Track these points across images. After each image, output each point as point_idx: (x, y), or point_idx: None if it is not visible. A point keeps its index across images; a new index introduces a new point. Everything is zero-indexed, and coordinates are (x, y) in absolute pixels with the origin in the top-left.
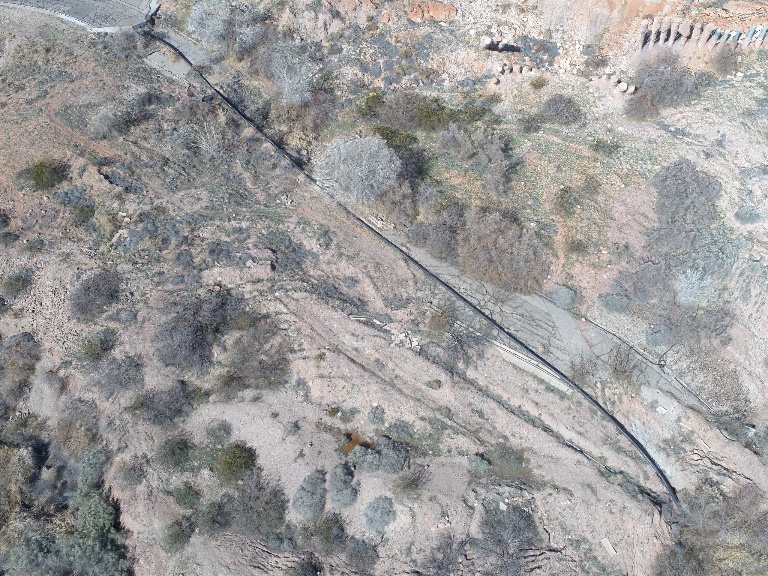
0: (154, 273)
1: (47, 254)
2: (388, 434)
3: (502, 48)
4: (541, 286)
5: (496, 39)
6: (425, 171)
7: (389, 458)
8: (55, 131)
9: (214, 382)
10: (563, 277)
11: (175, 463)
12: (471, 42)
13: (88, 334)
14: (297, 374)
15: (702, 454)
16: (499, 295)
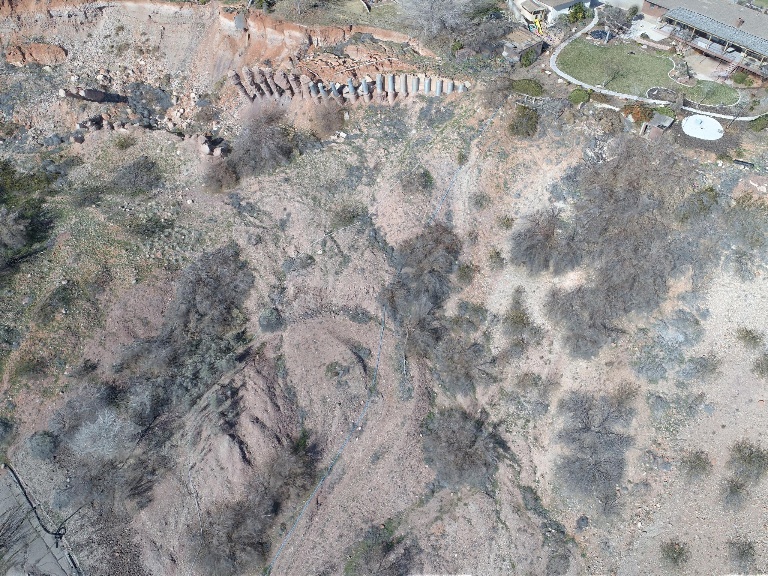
0: None
1: None
2: None
3: (103, 98)
4: None
5: (71, 91)
6: None
7: None
8: None
9: None
10: (3, 407)
11: None
12: None
13: None
14: None
15: None
16: None
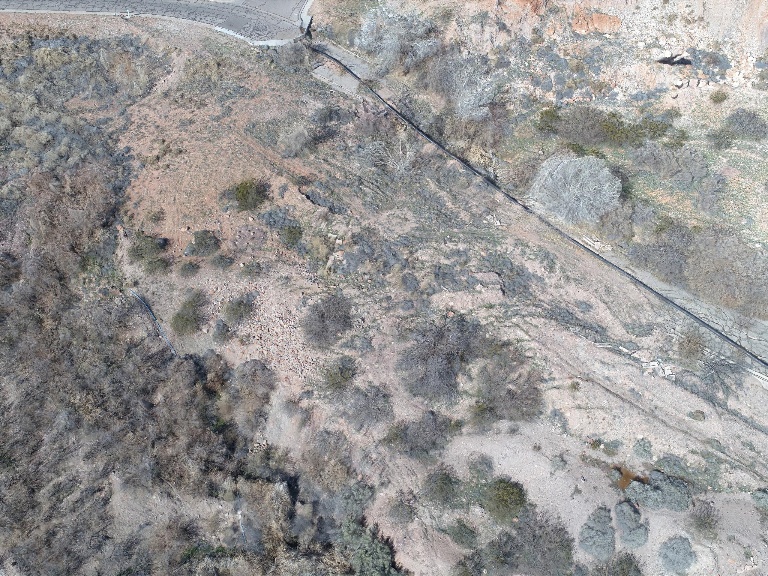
0: (381, 298)
1: (266, 278)
2: (659, 468)
3: None
4: None
5: (676, 52)
6: (626, 189)
7: (673, 495)
8: (249, 149)
9: (463, 413)
10: None
11: (443, 499)
12: (641, 55)
13: (325, 362)
14: (552, 405)
15: None
16: (740, 320)
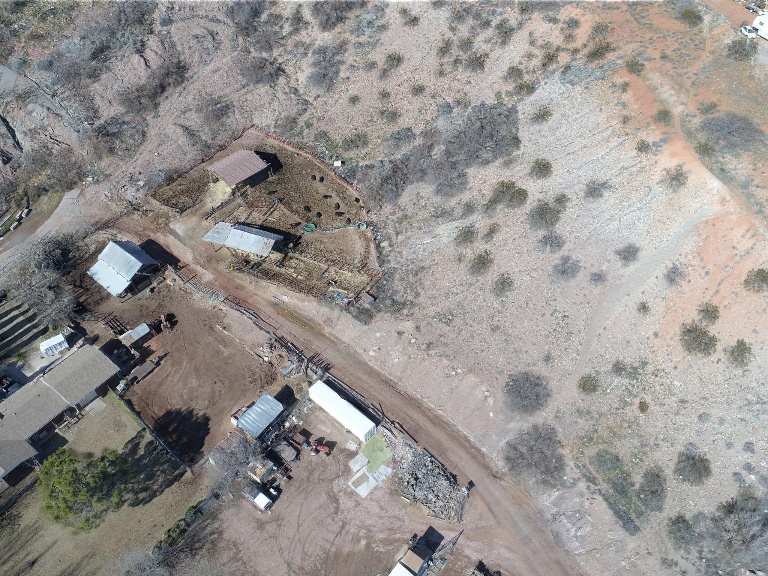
0: None
1: None
2: None
3: None
4: (7, 60)
5: None
6: None
7: None
8: None
9: None
10: (22, 54)
11: None
12: None
13: None
14: None
15: (49, 135)
16: None
